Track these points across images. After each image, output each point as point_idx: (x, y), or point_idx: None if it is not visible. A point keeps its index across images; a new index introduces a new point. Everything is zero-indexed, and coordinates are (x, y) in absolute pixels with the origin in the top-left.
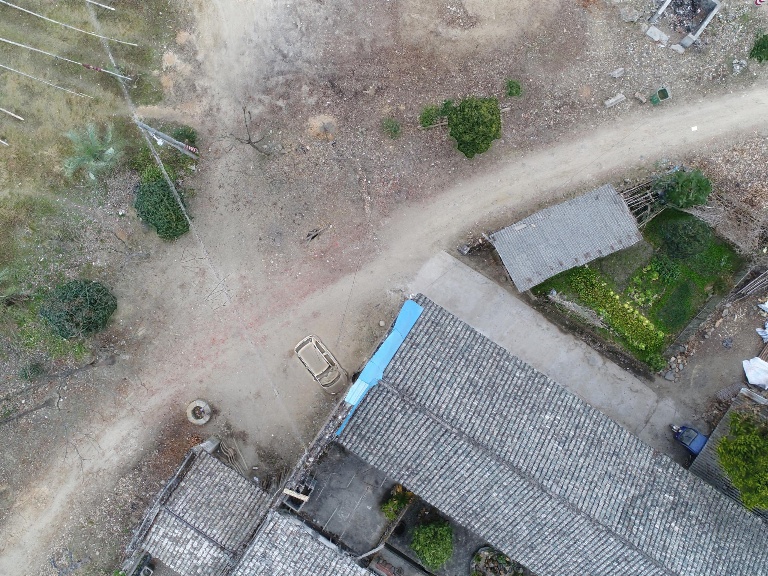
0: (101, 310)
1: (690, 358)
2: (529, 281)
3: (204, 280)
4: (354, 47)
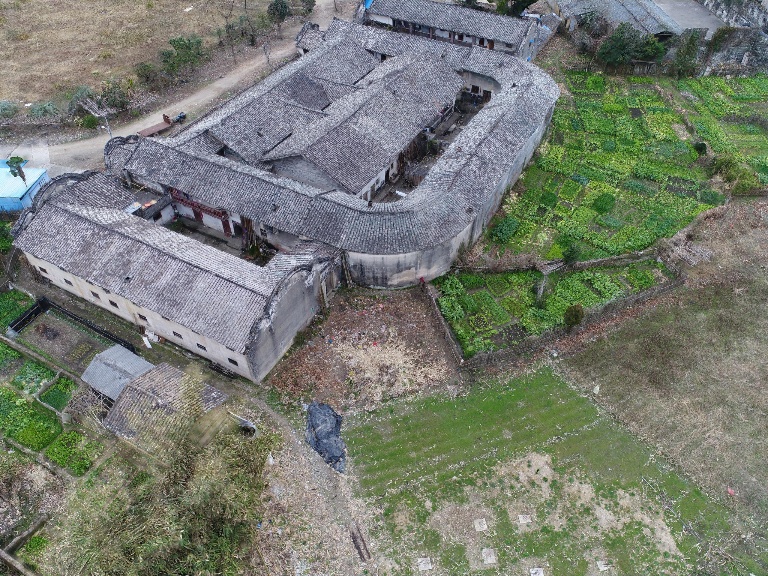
0: None
1: None
2: None
3: None
4: None
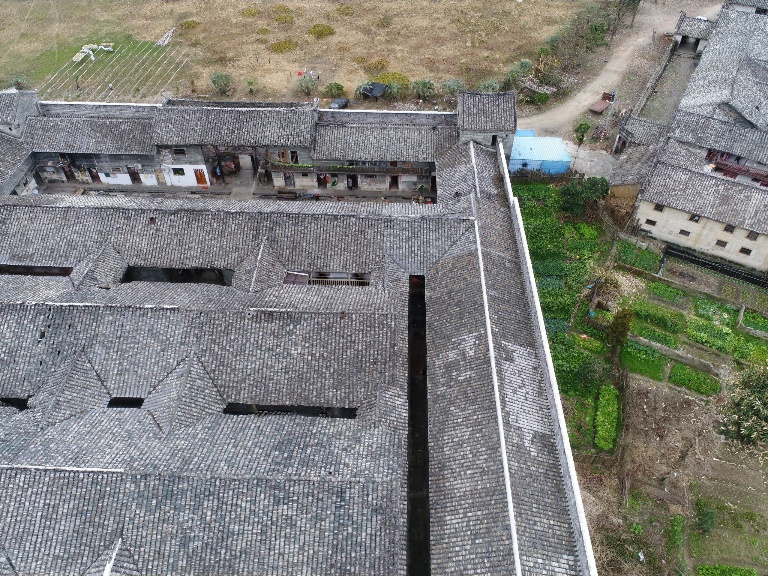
0: None
1: None
2: None
3: None
4: None
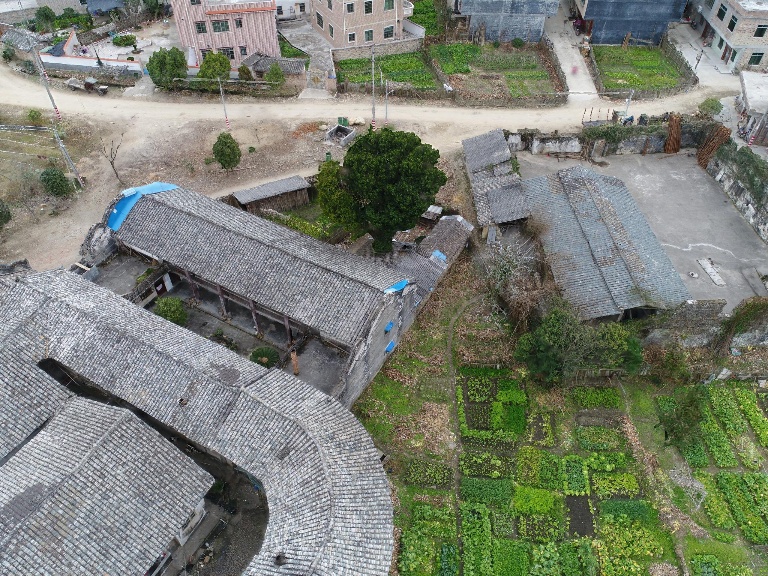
0: (1, 208)
1: (351, 246)
2: (248, 200)
3: (68, 230)
4: (180, 152)
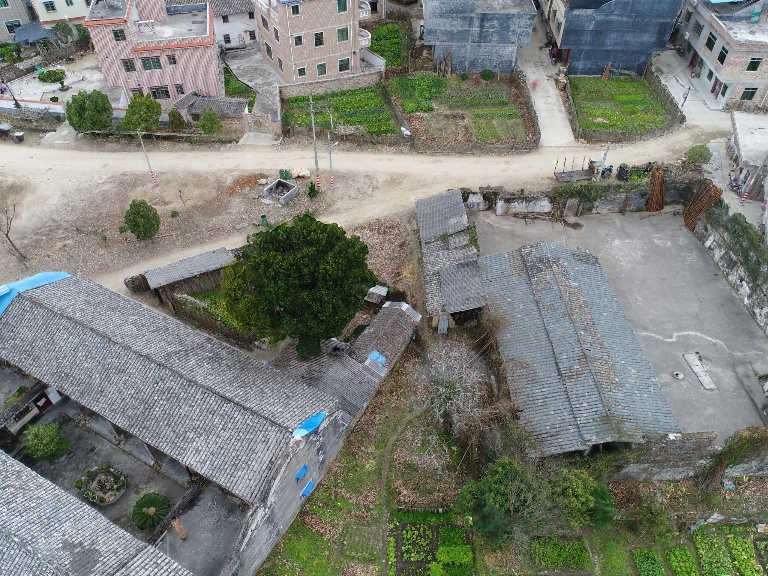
0: None
1: None
2: (159, 284)
3: None
4: (96, 215)
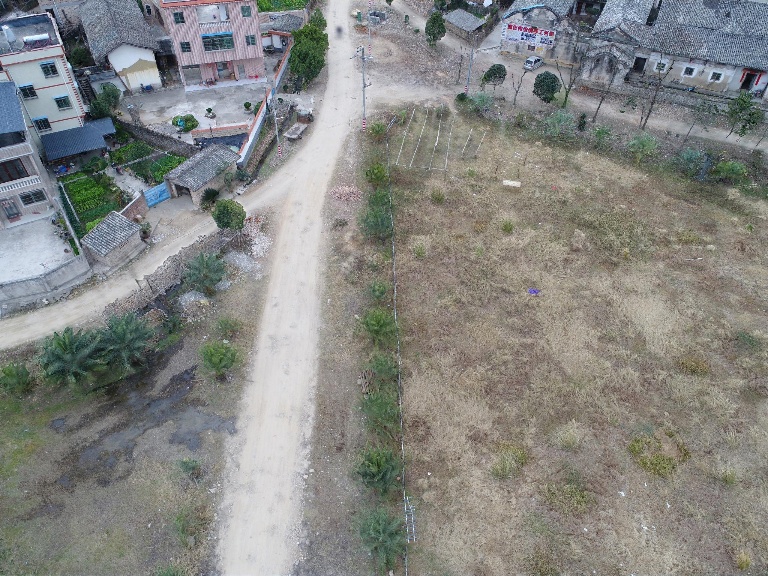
0: None
1: None
2: None
3: None
4: None
